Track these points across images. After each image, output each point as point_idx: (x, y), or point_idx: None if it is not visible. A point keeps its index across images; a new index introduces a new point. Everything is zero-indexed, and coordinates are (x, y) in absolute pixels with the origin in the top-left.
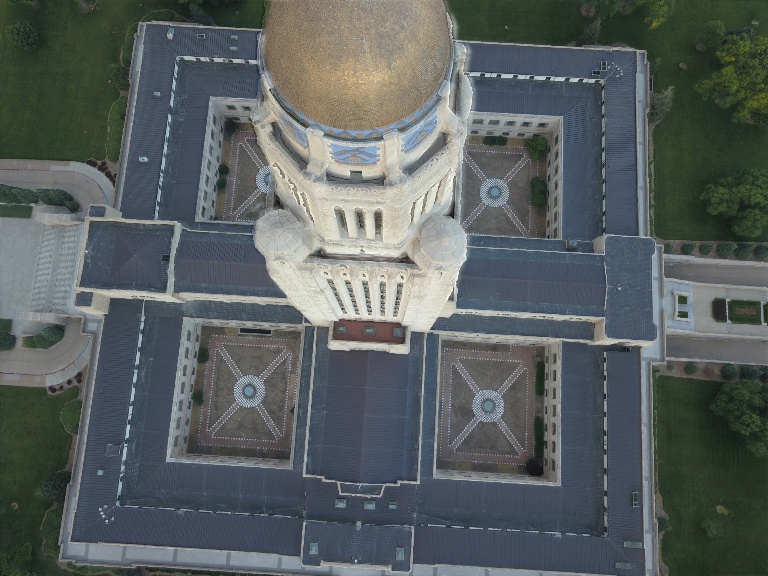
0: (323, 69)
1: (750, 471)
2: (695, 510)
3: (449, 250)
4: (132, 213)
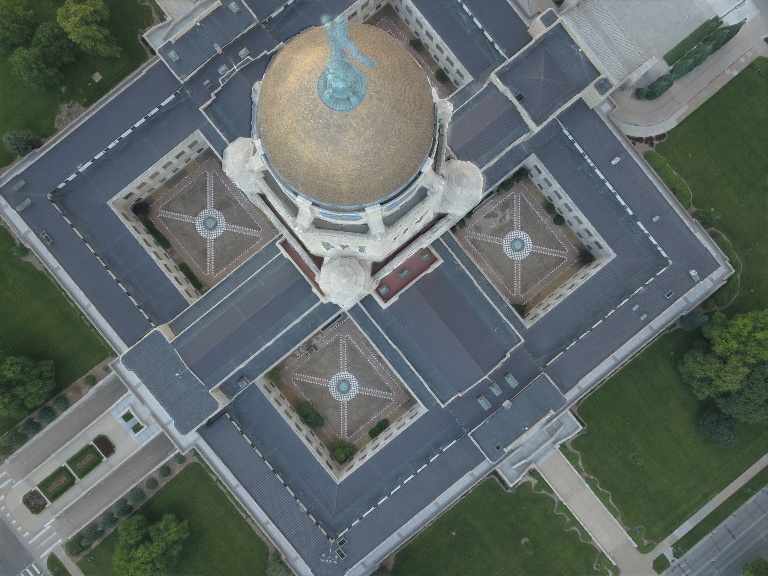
0: (315, 30)
1: None
2: (8, 282)
3: (233, 154)
4: (584, 116)
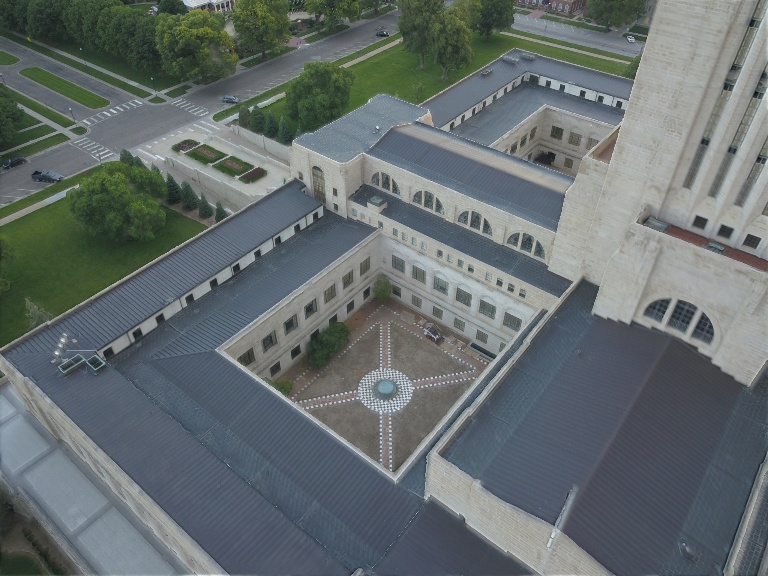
0: None
1: (352, 107)
2: None
3: None
4: None
